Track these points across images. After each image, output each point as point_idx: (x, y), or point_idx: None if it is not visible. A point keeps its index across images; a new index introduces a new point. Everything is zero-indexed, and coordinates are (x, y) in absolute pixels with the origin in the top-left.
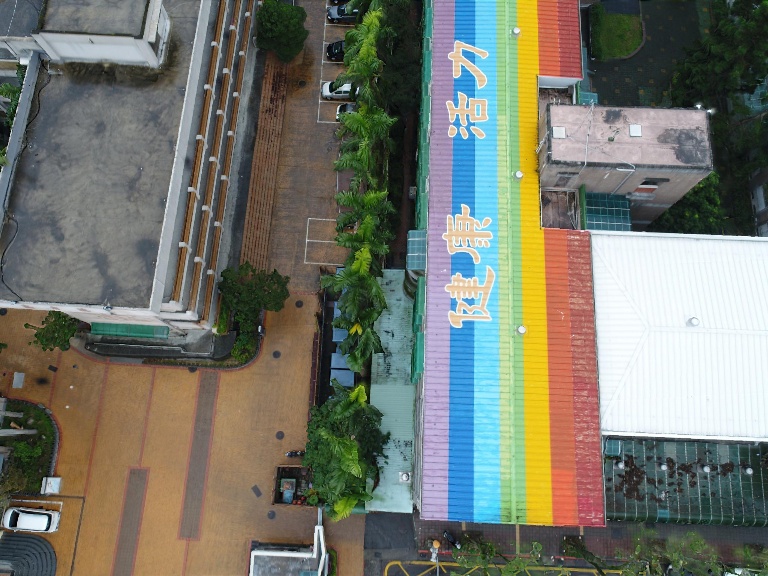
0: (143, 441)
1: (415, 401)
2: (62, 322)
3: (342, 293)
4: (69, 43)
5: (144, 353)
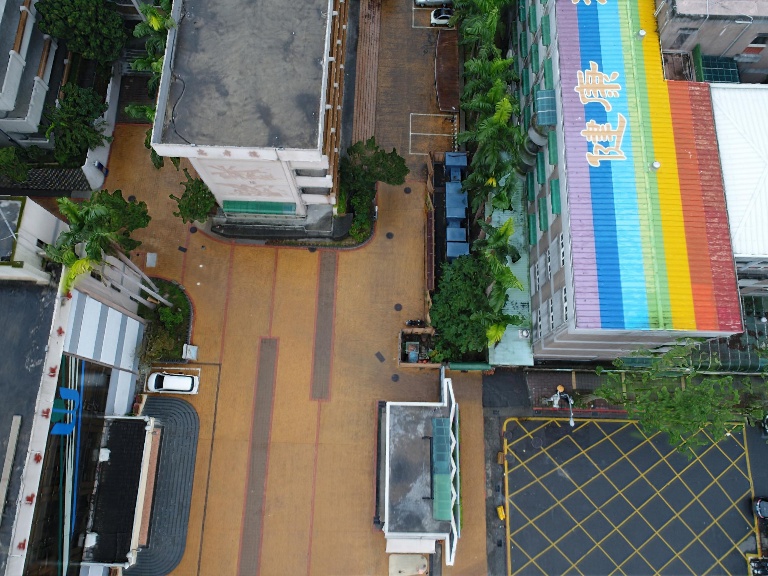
0: (271, 314)
1: (529, 267)
2: (202, 195)
3: (451, 176)
4: None
5: (268, 234)
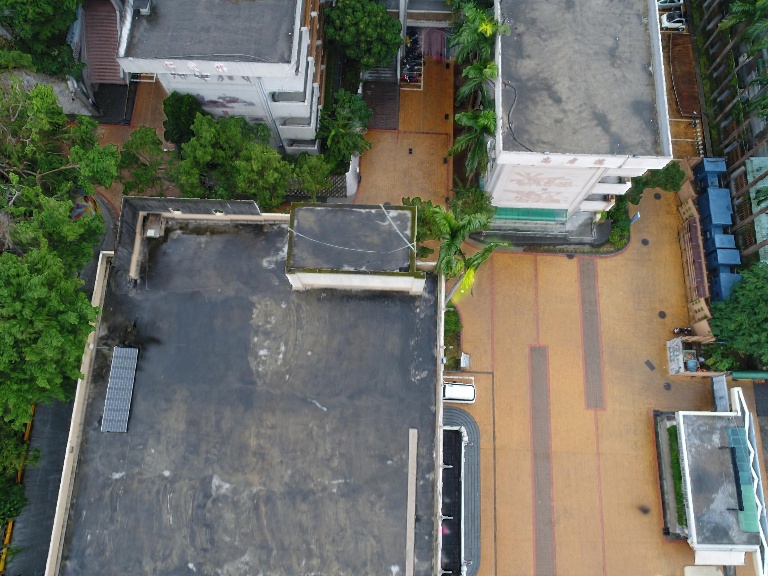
0: (537, 321)
1: None
2: (486, 202)
3: (708, 182)
4: None
5: (528, 241)
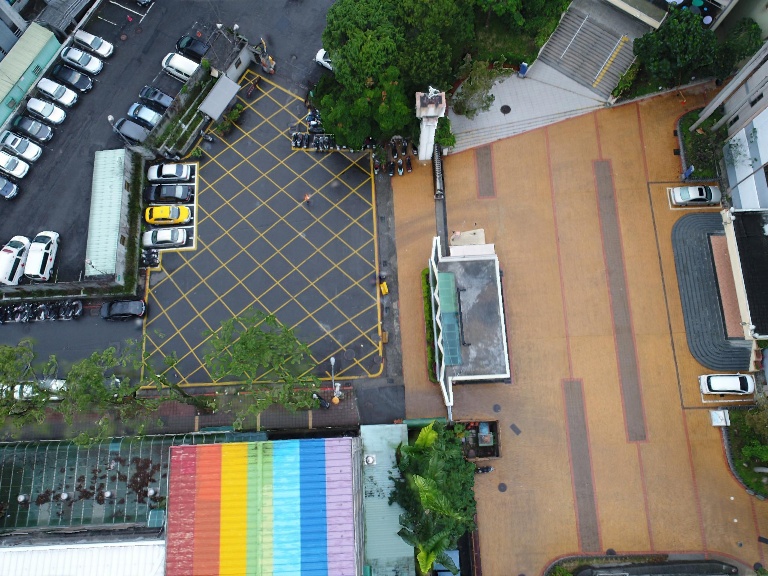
0: (642, 469)
1: (365, 542)
2: None
3: None
4: None
5: (670, 568)
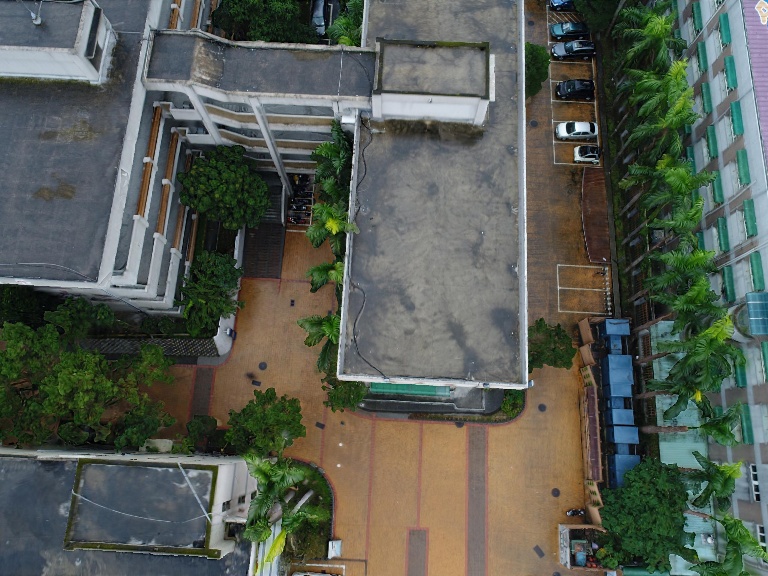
0: (418, 500)
1: (709, 459)
2: (355, 383)
3: (611, 345)
4: (404, 102)
5: (413, 409)
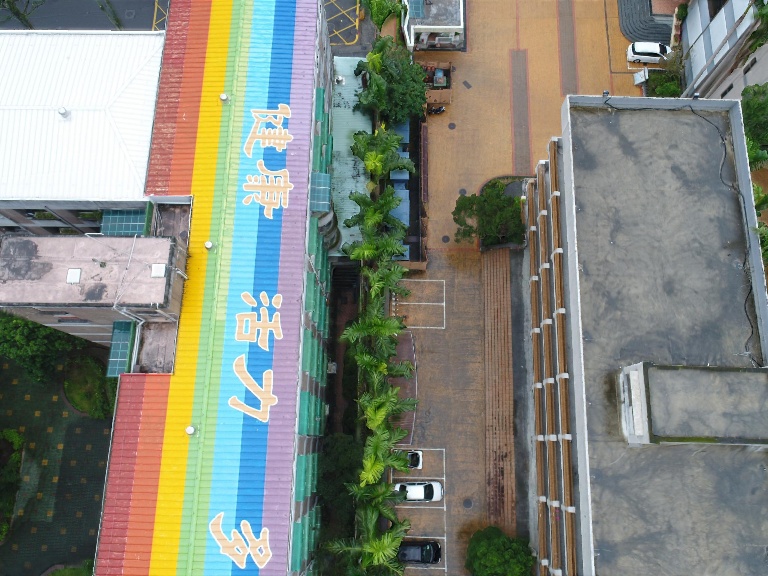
0: None
1: None
2: None
3: None
4: None
5: None
